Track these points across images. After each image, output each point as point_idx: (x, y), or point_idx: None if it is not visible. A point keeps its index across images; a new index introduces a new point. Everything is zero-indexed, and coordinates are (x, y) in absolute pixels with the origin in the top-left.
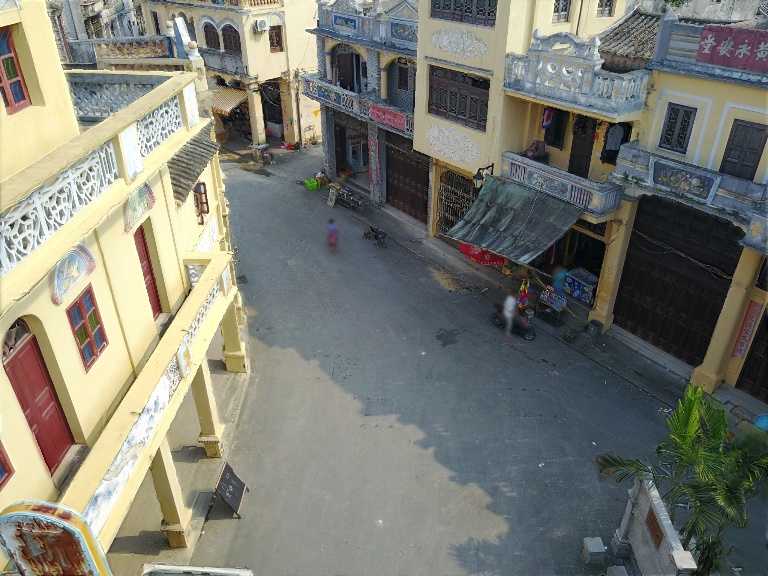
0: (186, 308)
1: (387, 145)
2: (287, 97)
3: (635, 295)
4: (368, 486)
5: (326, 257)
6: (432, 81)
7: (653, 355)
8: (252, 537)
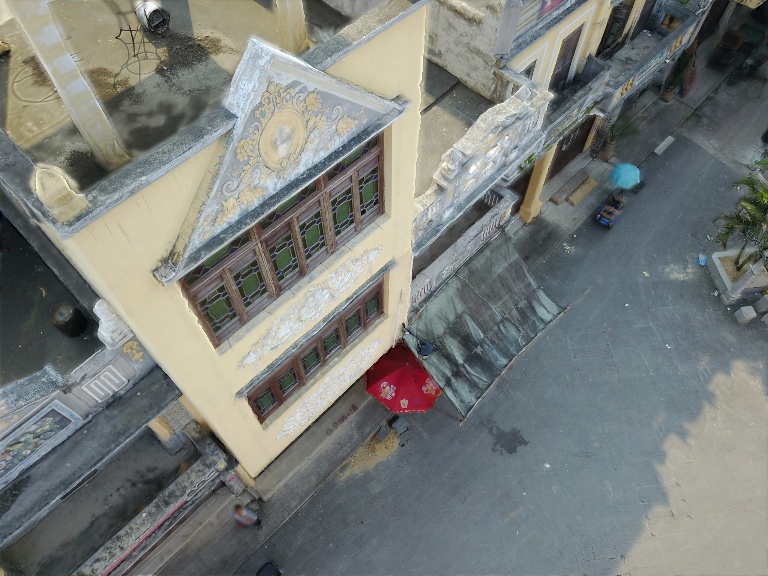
0: None
1: None
2: None
3: None
4: (760, 494)
5: None
6: (252, 396)
7: None
8: None
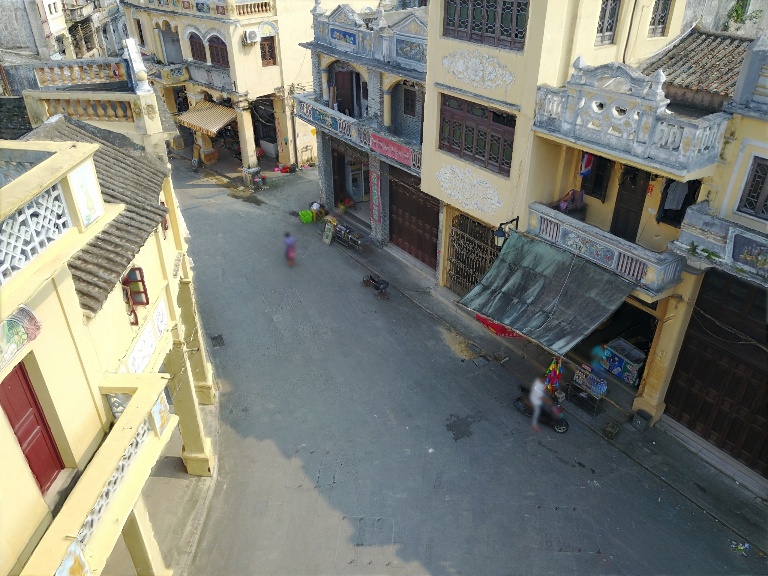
0: (82, 487)
1: (390, 179)
2: (281, 115)
3: (695, 384)
4: None
5: (318, 311)
6: (444, 112)
7: (717, 461)
8: None
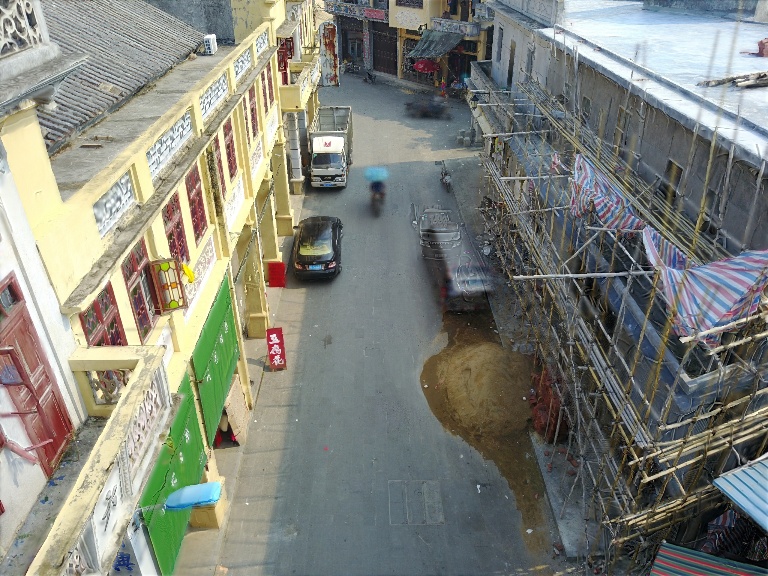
0: None
1: (374, 32)
2: None
3: None
4: (379, 131)
5: (345, 88)
6: None
7: None
8: None
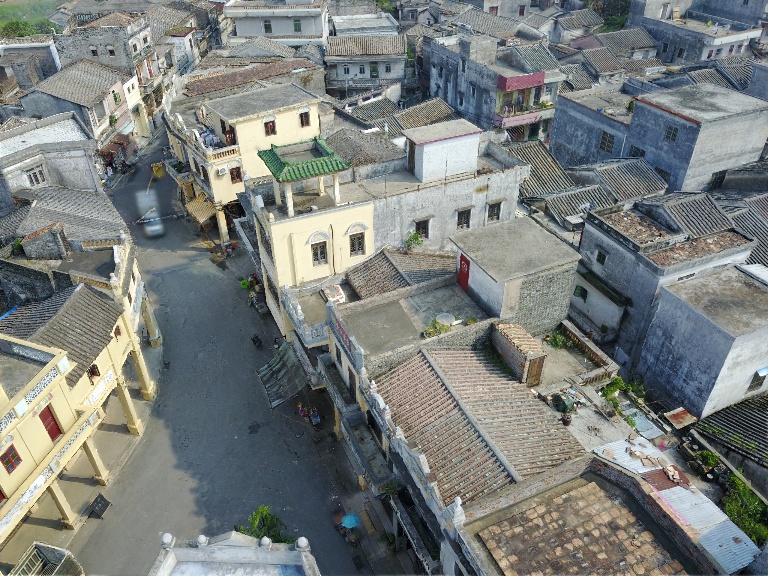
0: (61, 442)
1: None
2: None
3: None
4: (165, 513)
5: (222, 354)
6: None
7: (352, 461)
8: (104, 530)
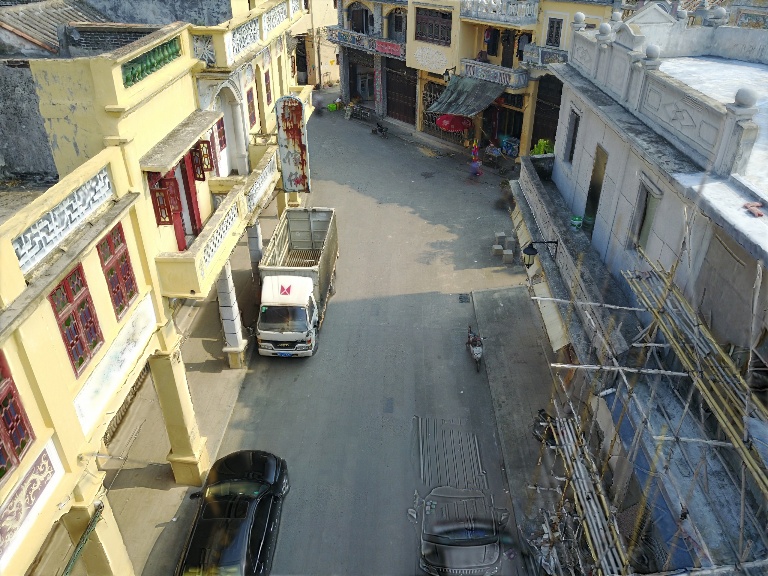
0: None
1: (388, 70)
2: (311, 49)
3: None
4: (383, 226)
5: (347, 143)
6: (417, 18)
7: None
8: None
